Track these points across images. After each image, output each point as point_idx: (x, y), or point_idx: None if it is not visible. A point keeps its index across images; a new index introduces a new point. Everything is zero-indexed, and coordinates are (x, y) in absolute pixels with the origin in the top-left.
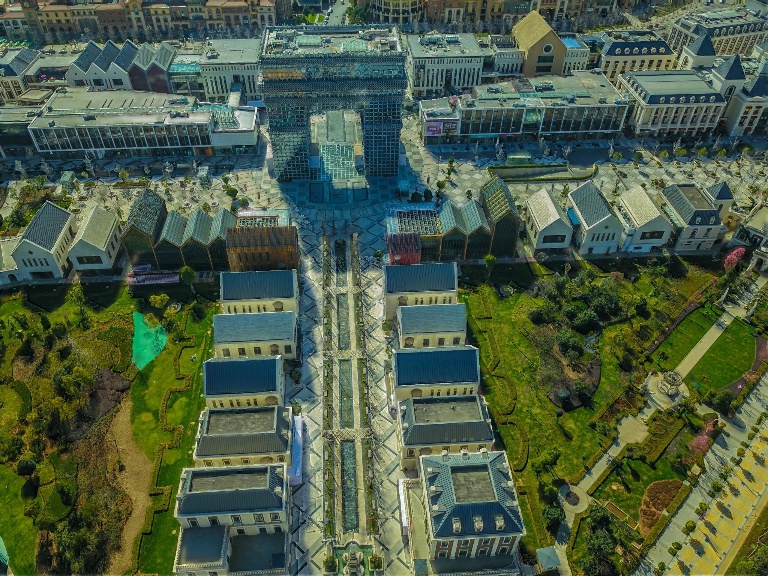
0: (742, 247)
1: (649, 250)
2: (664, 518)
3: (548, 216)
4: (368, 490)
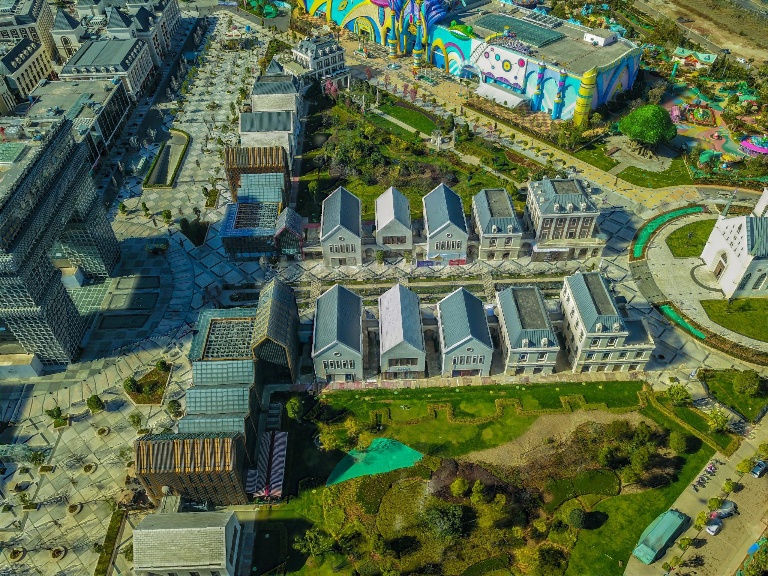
0: (311, 88)
1: (300, 125)
2: (531, 160)
3: (279, 141)
4: (537, 276)
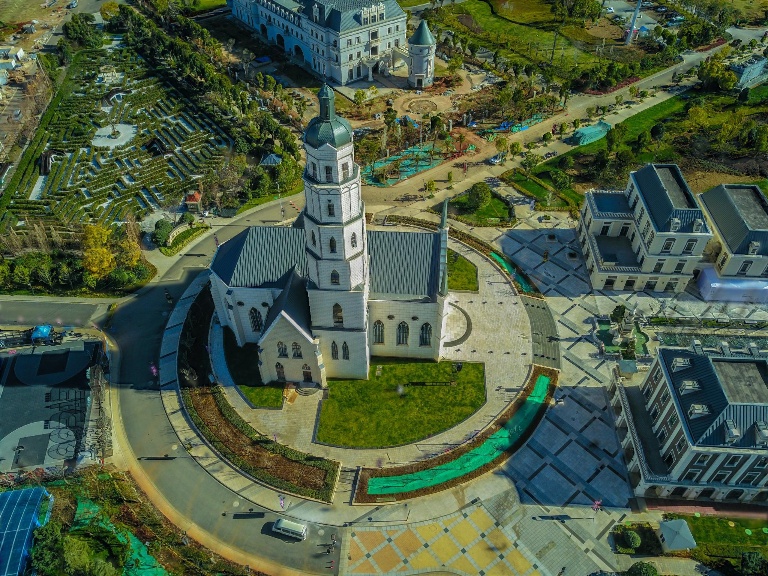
0: None
1: None
2: None
3: None
4: None
